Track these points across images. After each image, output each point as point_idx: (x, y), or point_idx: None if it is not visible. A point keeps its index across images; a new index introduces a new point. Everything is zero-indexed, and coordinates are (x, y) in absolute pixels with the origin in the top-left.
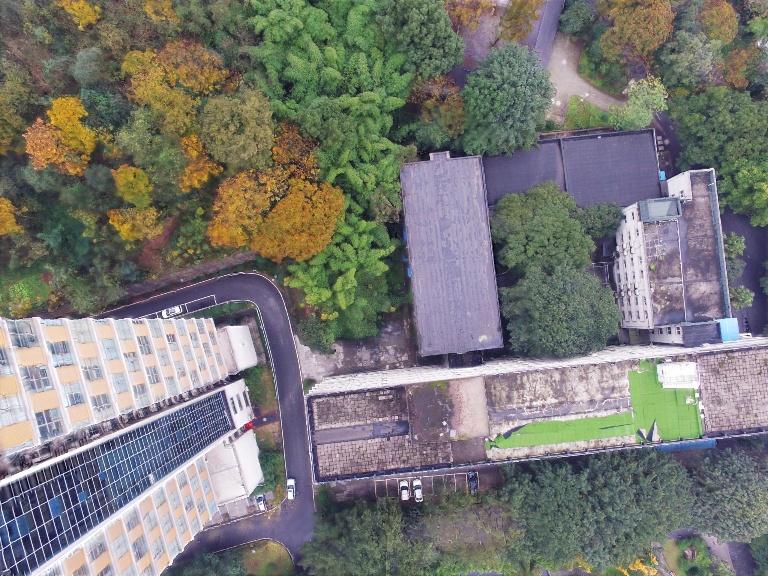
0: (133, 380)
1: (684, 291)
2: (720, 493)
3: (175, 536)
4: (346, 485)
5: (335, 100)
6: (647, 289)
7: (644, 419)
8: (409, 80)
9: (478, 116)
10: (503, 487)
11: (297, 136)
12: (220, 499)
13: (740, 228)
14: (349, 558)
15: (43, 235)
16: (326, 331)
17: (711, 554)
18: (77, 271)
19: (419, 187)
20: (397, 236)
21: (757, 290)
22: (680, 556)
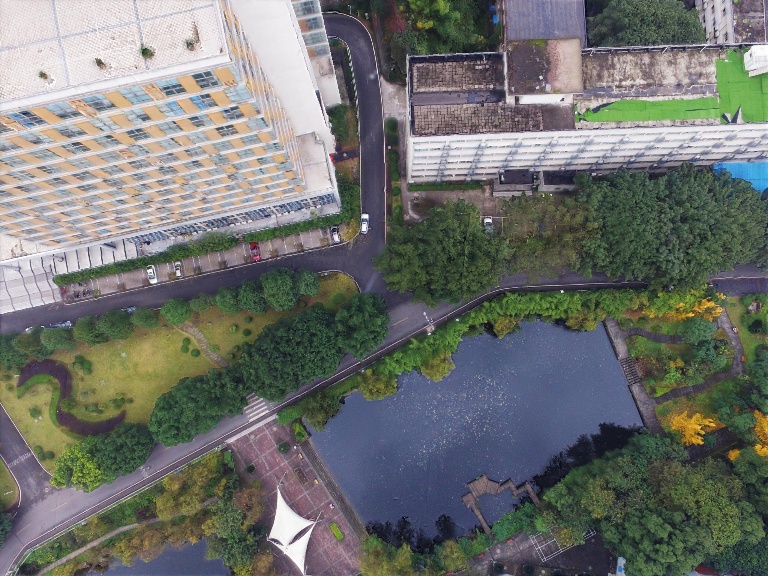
0: None
1: (766, 25)
2: None
3: None
4: (419, 219)
5: None
6: (730, 19)
7: (729, 104)
8: None
9: None
10: (581, 192)
11: None
12: None
13: None
14: (430, 241)
15: None
16: (419, 44)
17: None
18: None
19: None
20: None
21: None
22: (743, 313)
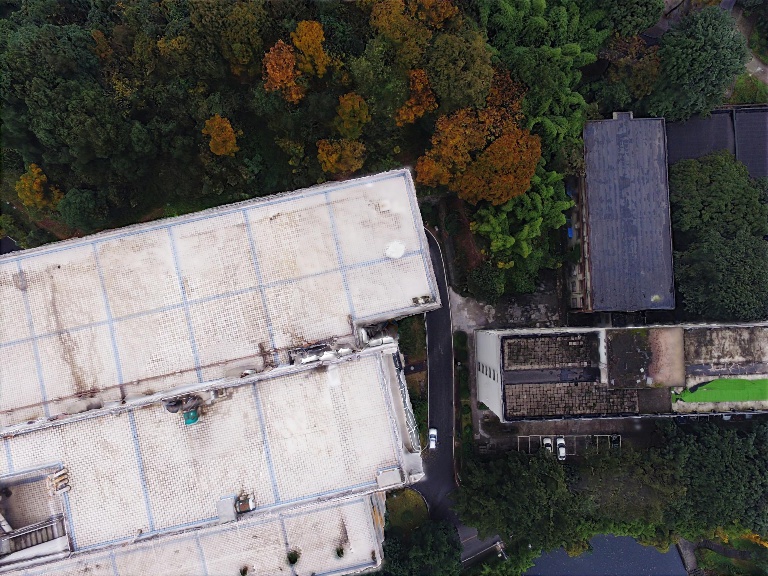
0: None
1: None
2: None
3: None
4: (489, 438)
5: (544, 48)
6: None
7: None
8: (606, 37)
9: (673, 76)
10: (667, 446)
11: (509, 80)
12: None
13: None
14: (514, 503)
15: (249, 161)
16: (498, 280)
17: None
18: None
19: (601, 145)
20: None
21: None
22: None
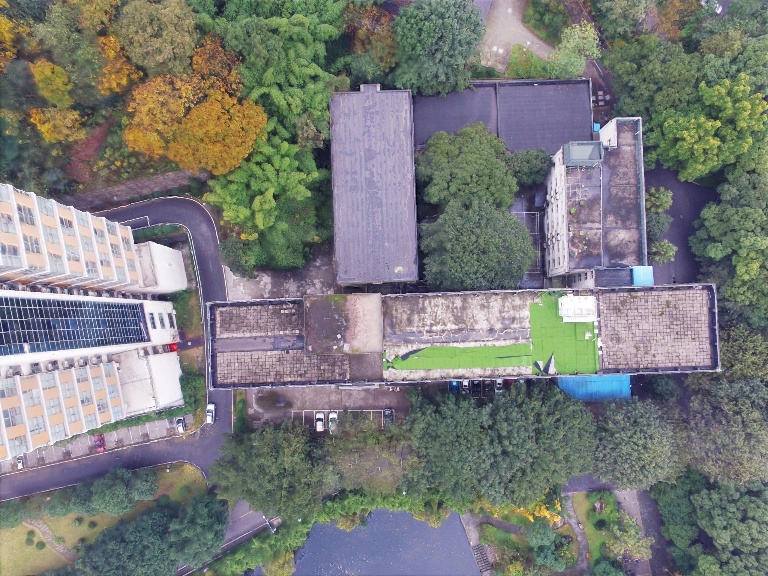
0: (2, 238)
1: (602, 237)
2: (619, 436)
3: (63, 421)
4: (263, 413)
5: (261, 17)
6: (565, 232)
7: (542, 351)
8: (341, 8)
9: (406, 47)
10: (407, 416)
11: (219, 48)
12: (130, 409)
13: (675, 188)
14: (248, 473)
15: None
16: (246, 253)
17: (620, 508)
18: (7, 176)
19: (347, 117)
20: (328, 169)
21: (686, 250)
22: (590, 509)
